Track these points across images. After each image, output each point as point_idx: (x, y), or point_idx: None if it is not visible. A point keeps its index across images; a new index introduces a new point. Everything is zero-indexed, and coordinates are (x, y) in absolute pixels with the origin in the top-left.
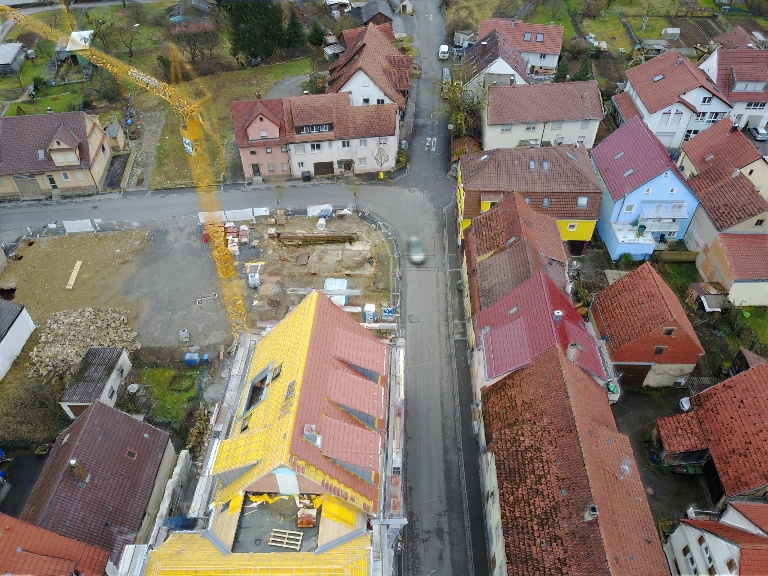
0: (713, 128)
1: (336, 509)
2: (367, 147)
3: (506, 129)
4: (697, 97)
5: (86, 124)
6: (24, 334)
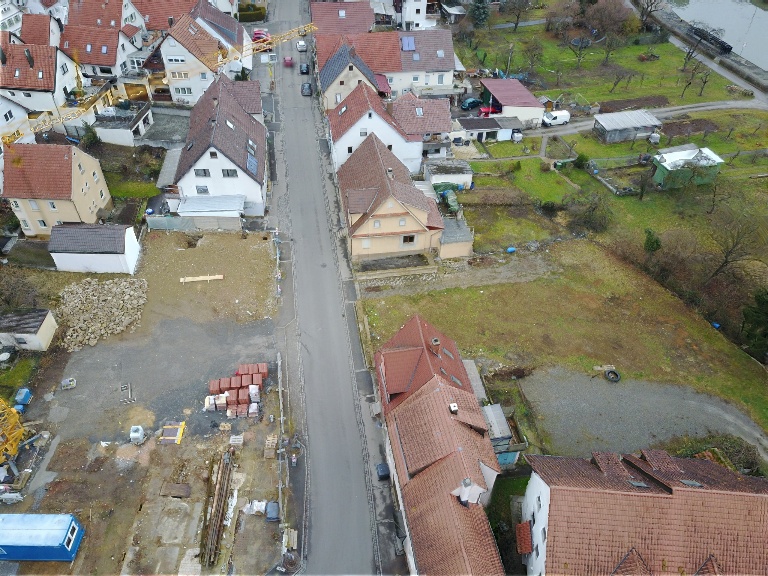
0: None
1: None
2: None
3: None
4: None
5: (390, 205)
6: (114, 267)
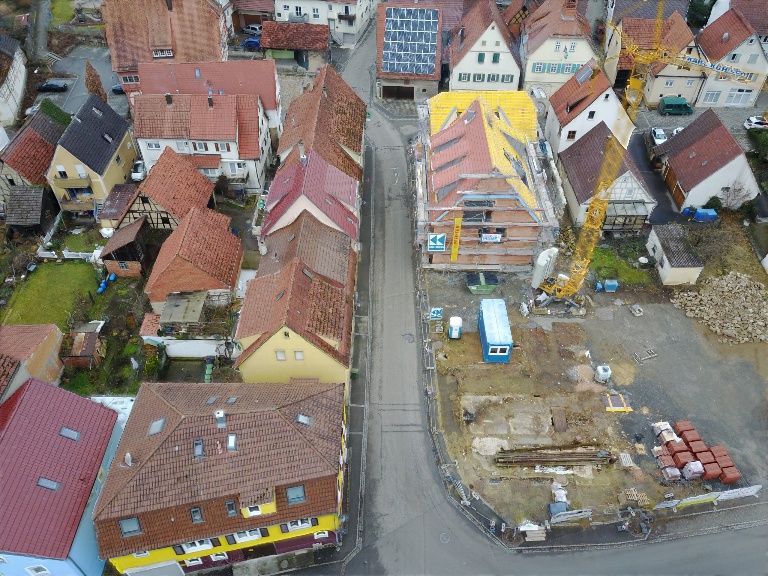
0: None
1: None
2: None
3: None
4: None
5: None
6: None
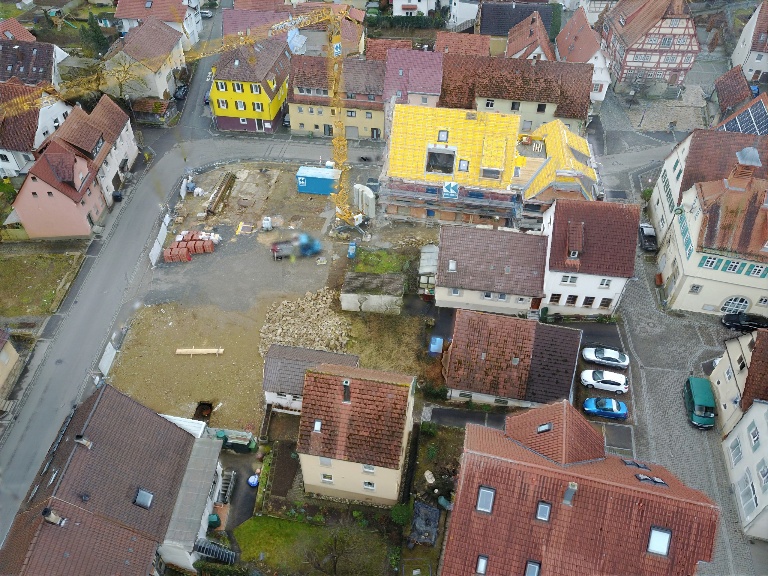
0: (238, 1)
1: None
2: (123, 141)
3: (159, 72)
4: (186, 1)
5: None
6: None
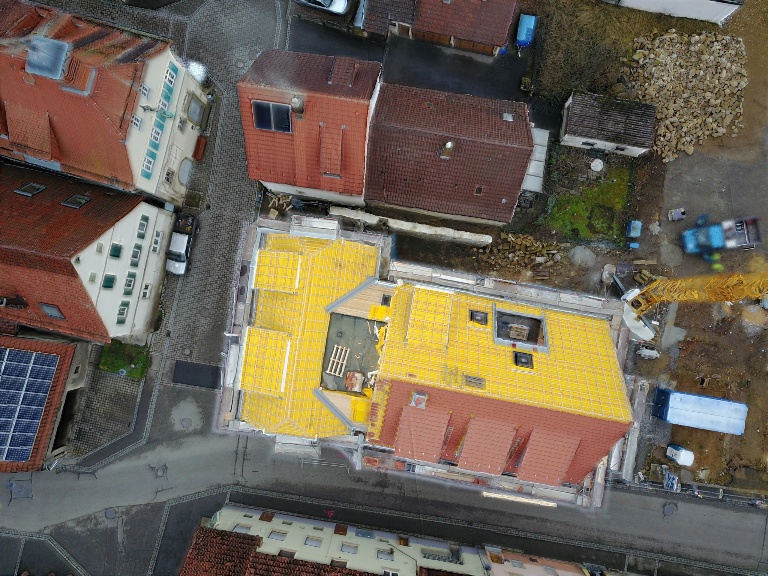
0: None
1: (362, 409)
2: None
3: None
4: None
5: None
6: (703, 14)
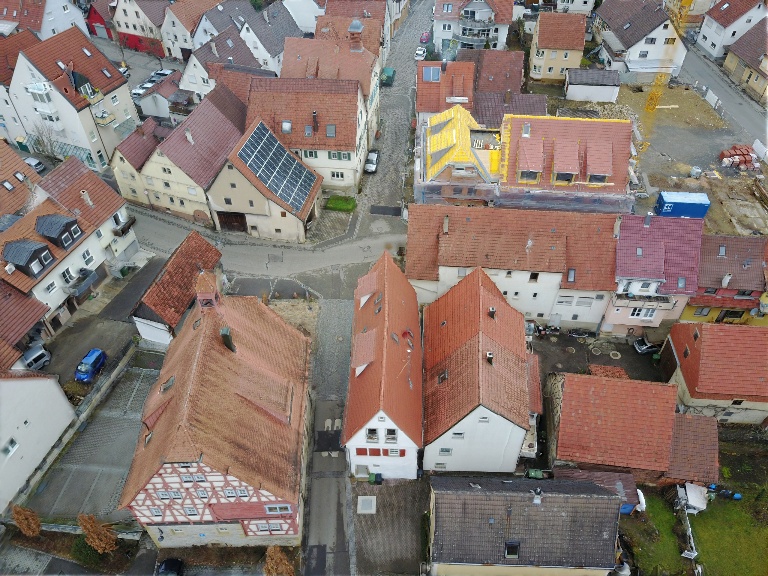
0: None
1: (495, 158)
2: None
3: None
4: None
5: None
6: (606, 98)
